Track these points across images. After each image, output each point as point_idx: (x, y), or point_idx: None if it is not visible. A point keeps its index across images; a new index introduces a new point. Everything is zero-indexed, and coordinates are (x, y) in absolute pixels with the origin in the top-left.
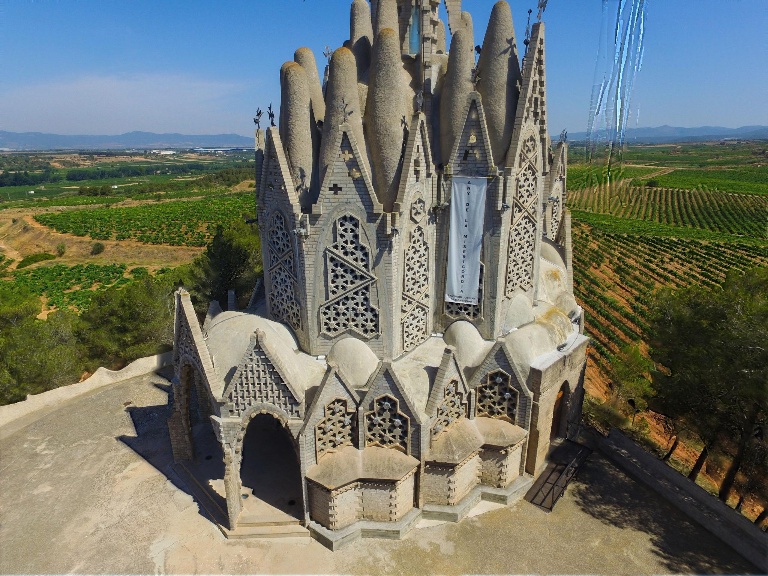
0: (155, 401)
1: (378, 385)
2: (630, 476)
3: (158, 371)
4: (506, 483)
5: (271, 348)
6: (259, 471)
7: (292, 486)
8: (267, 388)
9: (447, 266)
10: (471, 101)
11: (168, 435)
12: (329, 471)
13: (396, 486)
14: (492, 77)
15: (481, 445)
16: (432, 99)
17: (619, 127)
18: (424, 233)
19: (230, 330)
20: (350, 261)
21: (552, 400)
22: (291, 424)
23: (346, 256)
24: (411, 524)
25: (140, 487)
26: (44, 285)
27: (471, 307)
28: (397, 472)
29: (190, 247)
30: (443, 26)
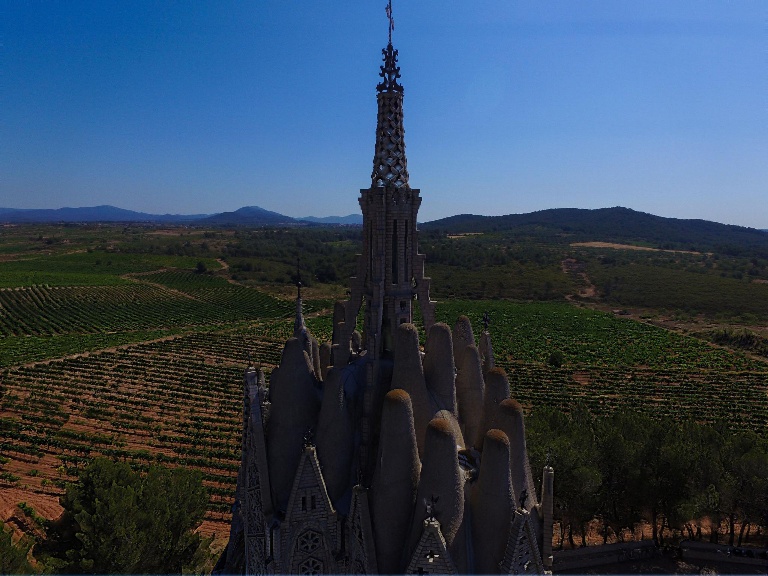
0: None
1: None
2: None
3: None
4: None
5: None
6: None
7: None
8: None
9: None
10: None
11: None
12: None
13: None
14: None
15: None
16: None
17: None
18: None
19: None
20: None
21: None
22: None
23: None
24: None
25: None
26: None
27: None
28: None
29: None
30: None
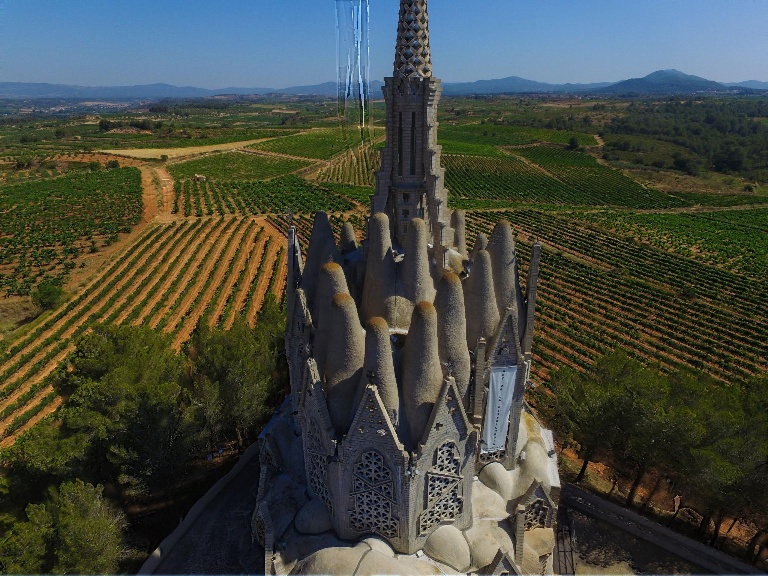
0: None
1: None
2: (589, 516)
3: None
4: None
5: None
6: None
7: None
8: None
9: (483, 430)
10: (508, 316)
11: None
12: None
13: None
14: (504, 281)
15: None
16: None
17: (365, 105)
18: None
19: None
20: (445, 474)
21: None
22: None
23: (442, 471)
24: None
25: None
26: None
27: (499, 451)
28: None
29: None
30: None
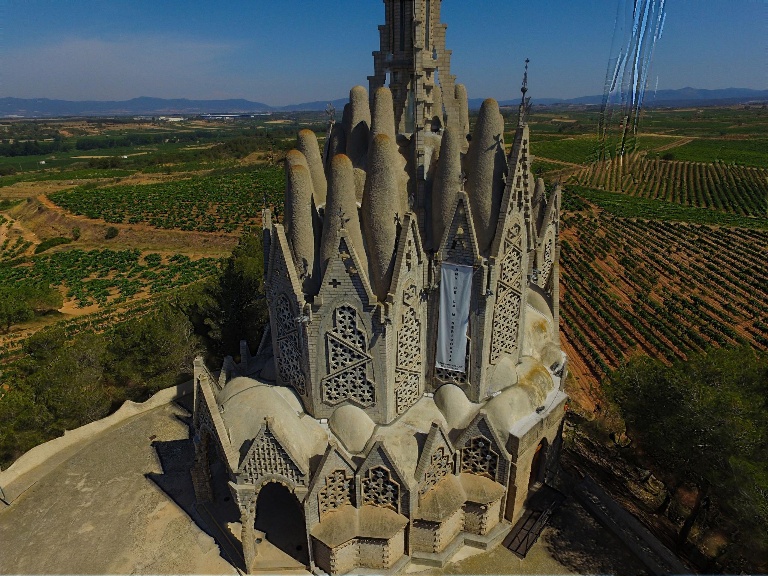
0: (177, 435)
1: (372, 458)
2: (599, 521)
3: (178, 400)
4: (486, 531)
5: (279, 431)
6: (271, 514)
7: (299, 531)
8: (276, 462)
9: (437, 338)
10: (458, 200)
11: (190, 473)
12: (330, 530)
13: (388, 542)
14: (480, 170)
15: (464, 502)
16: (425, 185)
17: (635, 102)
18: (416, 312)
19: (243, 405)
20: (348, 343)
21: (530, 457)
22: (297, 492)
23: (345, 338)
24: (401, 570)
25: (169, 528)
26: (63, 273)
27: (459, 373)
28: (389, 531)
29: (201, 232)
30: (439, 92)
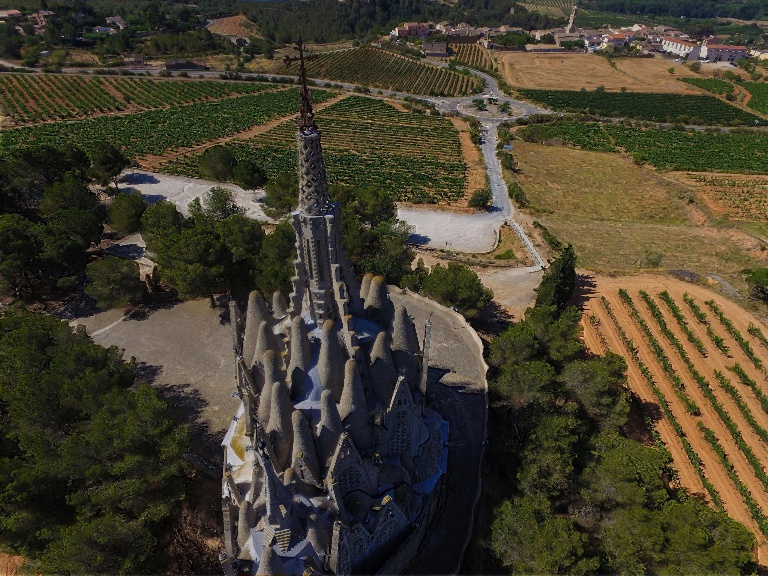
0: (446, 379)
1: None
2: None
3: (482, 395)
4: None
5: None
6: None
7: None
8: None
9: None
10: None
11: None
12: None
13: None
14: None
15: None
16: None
17: None
18: None
19: None
20: None
21: None
22: None
23: None
24: None
25: None
26: None
27: None
28: None
29: None
30: None
